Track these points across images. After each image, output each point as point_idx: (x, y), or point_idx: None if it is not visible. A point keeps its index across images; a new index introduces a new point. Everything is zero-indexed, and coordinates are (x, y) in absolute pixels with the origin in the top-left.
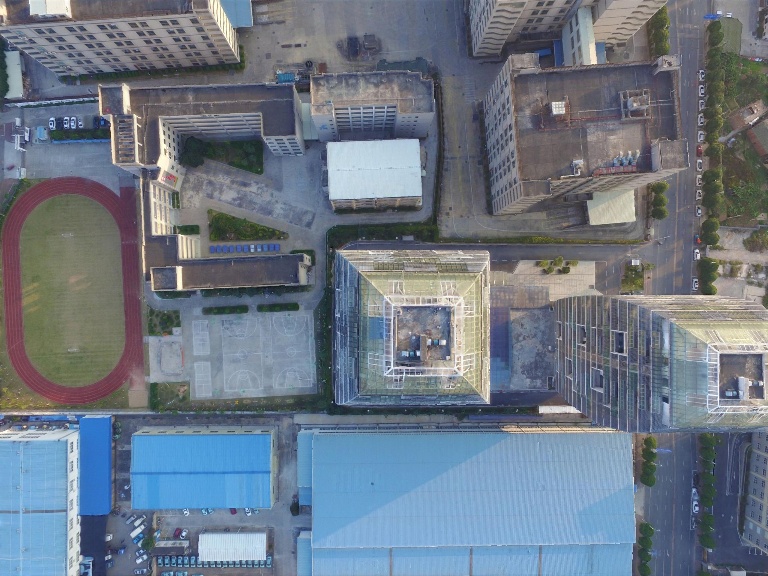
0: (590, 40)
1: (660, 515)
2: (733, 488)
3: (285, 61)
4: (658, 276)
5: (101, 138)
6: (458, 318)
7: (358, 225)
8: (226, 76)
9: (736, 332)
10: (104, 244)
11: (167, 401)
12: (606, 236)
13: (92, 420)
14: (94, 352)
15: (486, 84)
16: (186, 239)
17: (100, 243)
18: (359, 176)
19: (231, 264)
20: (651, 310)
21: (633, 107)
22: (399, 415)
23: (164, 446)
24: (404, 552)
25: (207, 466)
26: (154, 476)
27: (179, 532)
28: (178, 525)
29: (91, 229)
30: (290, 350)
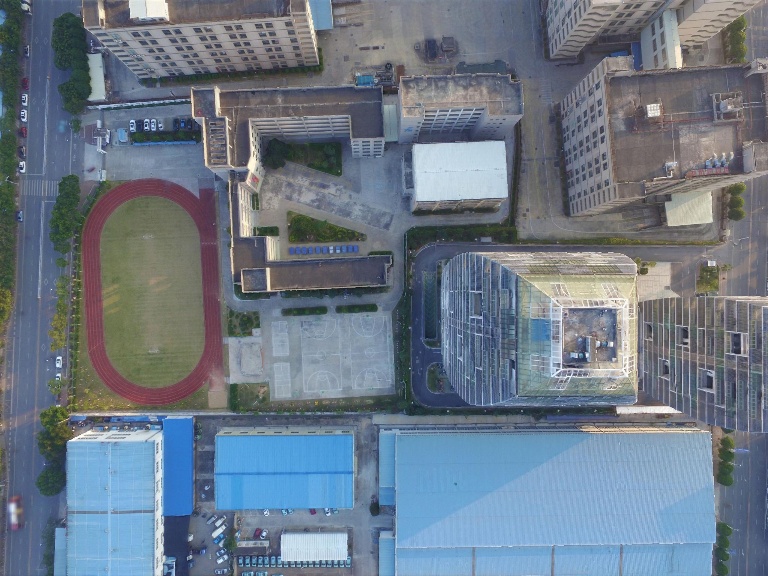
0: (675, 43)
1: (735, 514)
2: None
3: (363, 63)
4: (733, 277)
5: (181, 140)
6: (625, 320)
7: (436, 226)
8: (305, 78)
9: None
10: (184, 246)
11: (247, 402)
12: (681, 237)
13: (175, 421)
14: (174, 353)
15: (562, 86)
16: (271, 241)
17: (180, 245)
18: (446, 178)
19: (318, 265)
20: None
21: (727, 109)
22: (477, 415)
23: (247, 447)
24: (487, 552)
25: (290, 466)
26: (238, 476)
27: (259, 532)
28: (258, 525)
29: (171, 231)
30: (369, 351)
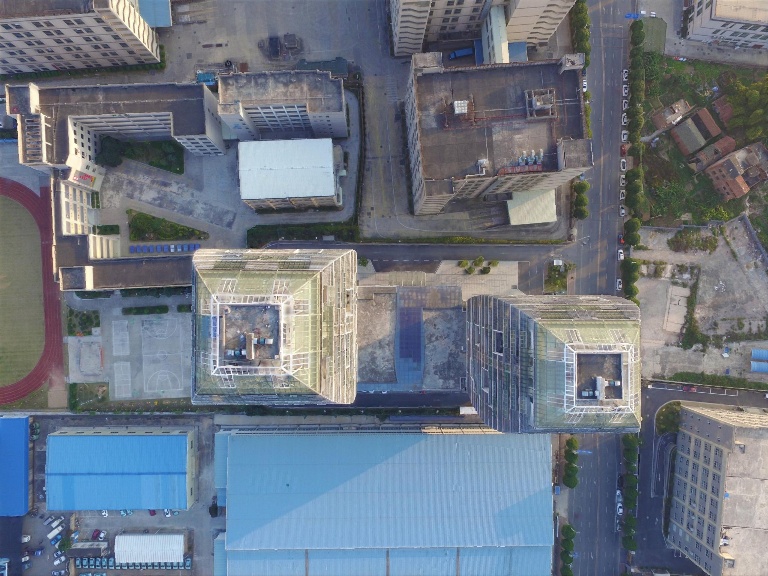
0: (502, 39)
1: (584, 517)
2: (658, 490)
3: (206, 61)
4: (582, 276)
5: None
6: (286, 317)
7: (279, 225)
8: (147, 76)
9: (597, 331)
10: (24, 244)
11: None
12: (529, 236)
13: (8, 421)
14: (13, 352)
15: None
16: (100, 239)
17: (20, 243)
18: (271, 176)
19: (142, 264)
20: (519, 309)
21: (537, 106)
22: (320, 416)
23: (79, 447)
24: (320, 554)
25: (122, 467)
26: (69, 477)
27: (97, 533)
28: (97, 526)
29: (11, 229)
30: None
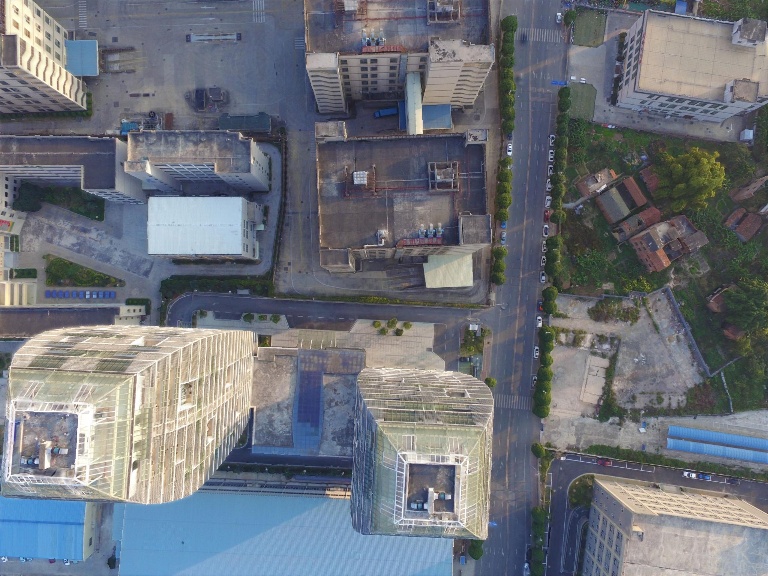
0: (417, 106)
1: None
2: (568, 565)
3: (132, 110)
4: (499, 342)
5: None
6: (84, 426)
7: (195, 276)
8: (73, 122)
9: (435, 439)
10: None
11: None
12: (447, 298)
13: None
14: None
15: None
16: (11, 285)
17: None
18: (179, 232)
19: (47, 314)
20: (367, 407)
21: (437, 180)
22: (226, 471)
23: None
24: None
25: (21, 514)
26: None
27: None
28: None
29: None
30: None
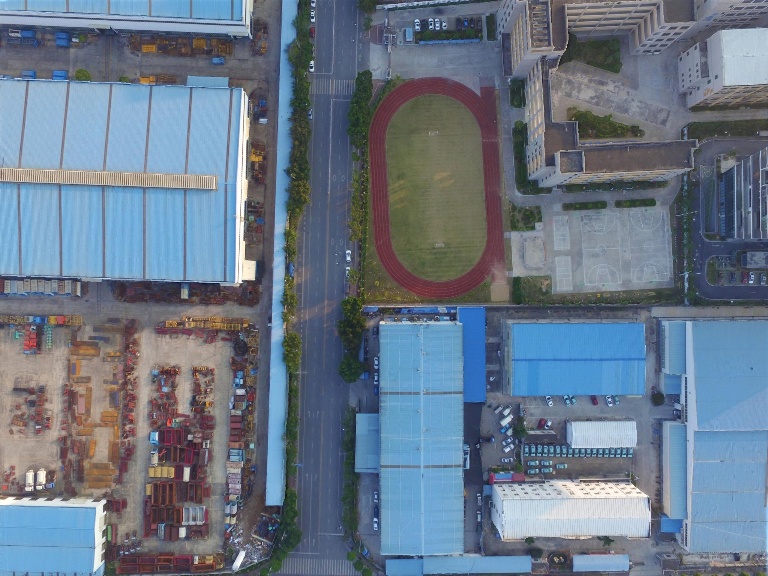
0: None
1: None
2: None
3: None
4: None
5: (466, 38)
6: None
7: (713, 122)
8: None
9: None
10: (466, 142)
11: (530, 294)
12: None
13: (470, 310)
14: (457, 247)
15: None
16: None
17: (462, 141)
18: (753, 62)
19: (626, 150)
20: None
21: None
22: (754, 308)
23: (543, 334)
24: None
25: (585, 353)
26: (535, 363)
27: (544, 422)
28: (541, 416)
29: (453, 128)
30: (647, 245)
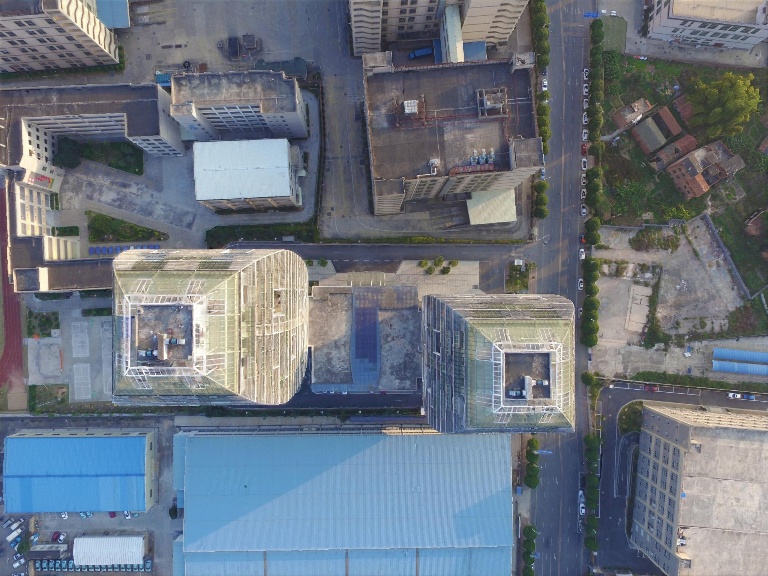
0: (457, 39)
1: (547, 518)
2: (621, 490)
3: (165, 62)
4: (543, 276)
5: None
6: (199, 317)
7: (239, 226)
8: (106, 77)
9: (527, 331)
10: None
11: None
12: (490, 236)
13: None
14: None
15: None
16: (57, 240)
17: None
18: (226, 176)
19: (98, 265)
20: (453, 309)
21: (487, 105)
22: (281, 417)
23: (37, 449)
24: (278, 556)
25: (80, 469)
26: (27, 479)
27: (57, 536)
28: (57, 529)
29: None
30: None
